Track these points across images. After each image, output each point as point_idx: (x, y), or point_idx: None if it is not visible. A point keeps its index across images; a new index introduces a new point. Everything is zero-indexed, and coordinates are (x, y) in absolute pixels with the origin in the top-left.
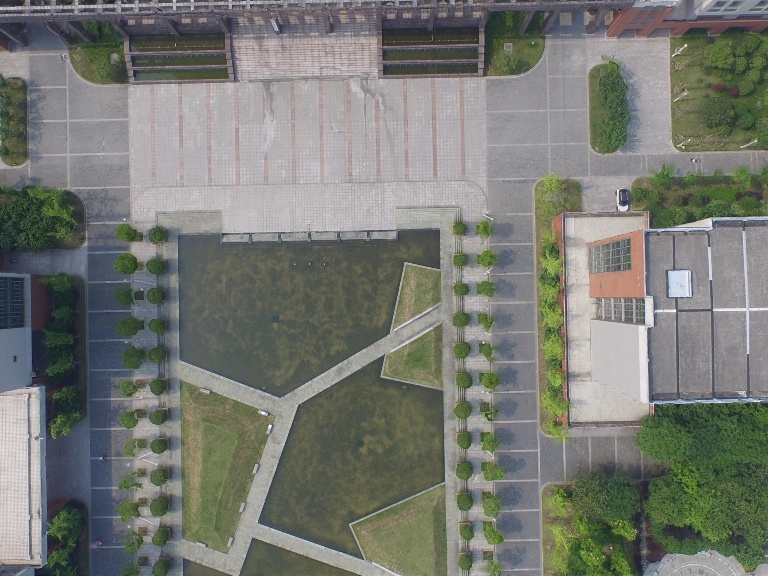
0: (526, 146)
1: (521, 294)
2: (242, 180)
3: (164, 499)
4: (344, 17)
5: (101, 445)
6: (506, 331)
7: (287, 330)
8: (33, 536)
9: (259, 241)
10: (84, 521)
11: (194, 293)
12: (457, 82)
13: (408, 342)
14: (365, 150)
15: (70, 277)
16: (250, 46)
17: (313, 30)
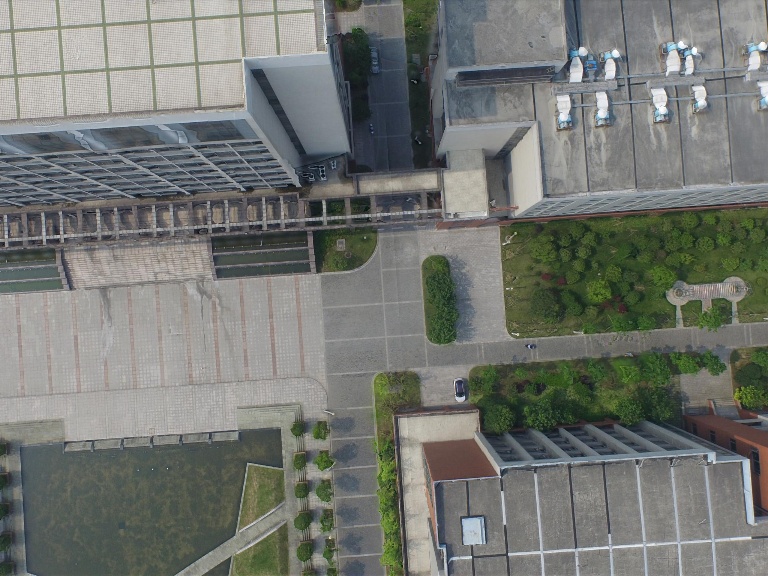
0: (363, 340)
1: (365, 487)
2: (83, 387)
3: None
4: None
5: None
6: (352, 525)
7: (134, 536)
8: None
9: (101, 449)
10: None
11: (39, 503)
12: (292, 280)
13: (253, 544)
14: (204, 351)
15: None
16: (82, 258)
17: None
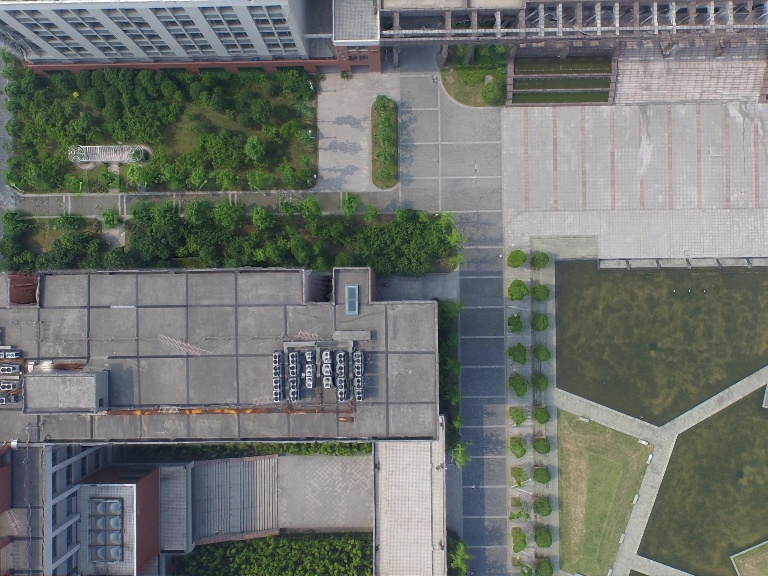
0: None
1: None
2: (617, 205)
3: (547, 530)
4: (735, 41)
5: (473, 473)
6: None
7: (665, 358)
8: (435, 568)
9: (637, 267)
10: None
11: (570, 319)
12: None
13: None
14: (743, 175)
15: (443, 302)
16: (635, 69)
17: (700, 54)
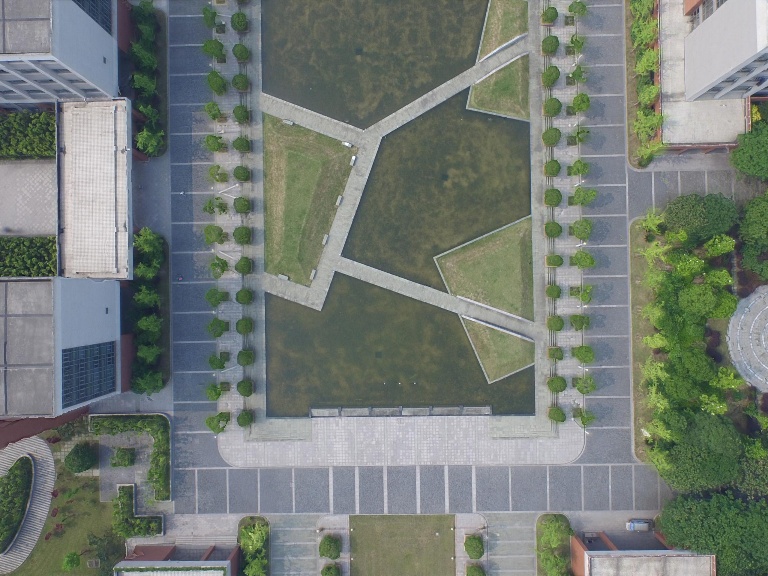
0: None
1: (609, 26)
2: None
3: None
4: None
5: (182, 180)
6: (594, 64)
7: (371, 63)
8: (119, 249)
9: None
10: (165, 255)
11: (276, 25)
12: None
13: (495, 71)
14: None
15: None
16: None
17: None
